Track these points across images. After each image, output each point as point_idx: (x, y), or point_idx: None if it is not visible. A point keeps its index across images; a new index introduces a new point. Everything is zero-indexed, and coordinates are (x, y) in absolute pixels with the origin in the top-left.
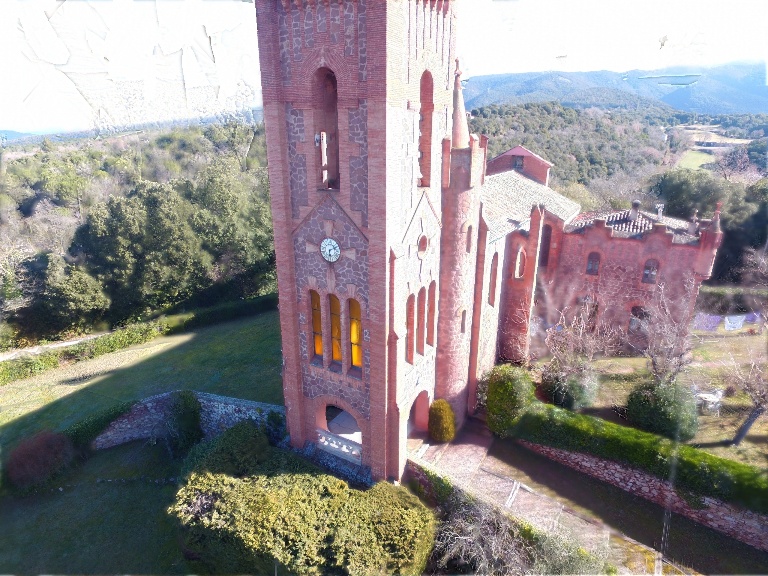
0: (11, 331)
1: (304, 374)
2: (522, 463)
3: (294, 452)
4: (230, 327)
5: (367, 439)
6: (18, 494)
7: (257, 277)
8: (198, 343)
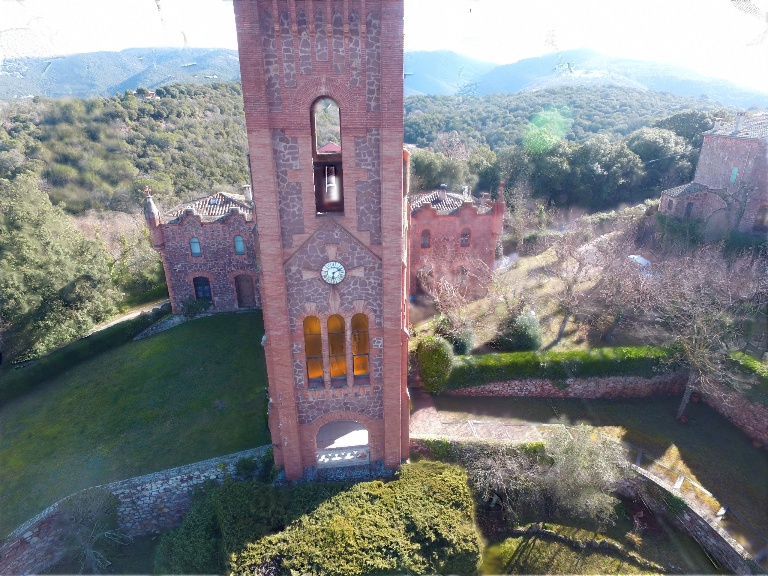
0: None
1: (299, 403)
2: (460, 407)
3: None
4: (36, 402)
5: (376, 436)
6: None
7: None
8: (3, 438)
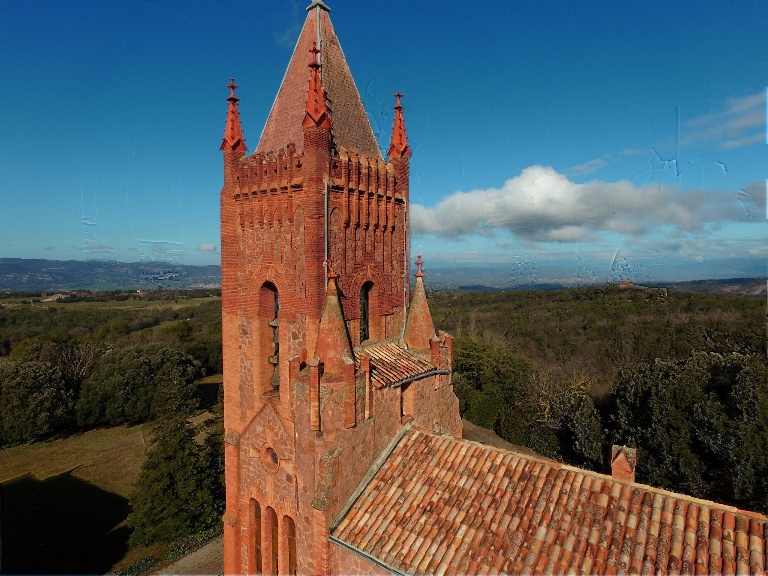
0: (556, 445)
1: None
2: None
3: None
4: None
5: None
6: None
7: None
8: None
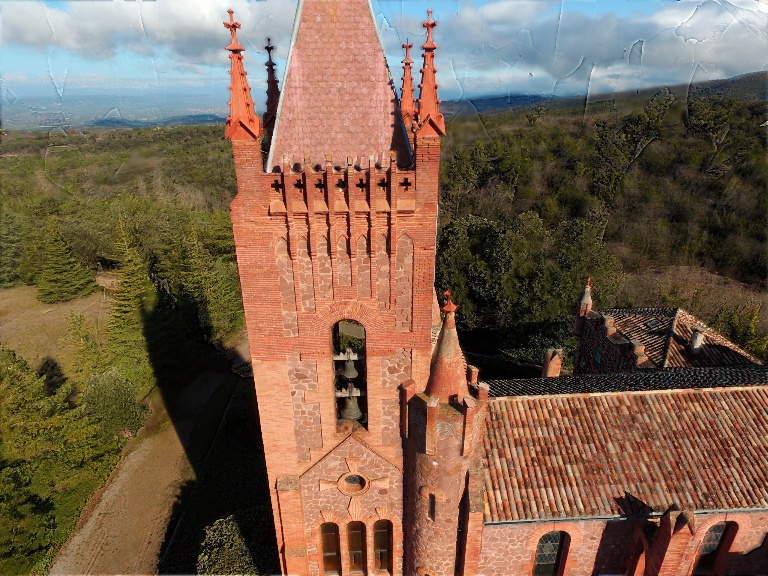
0: None
1: None
2: None
3: None
4: None
5: None
6: None
7: (525, 335)
8: None
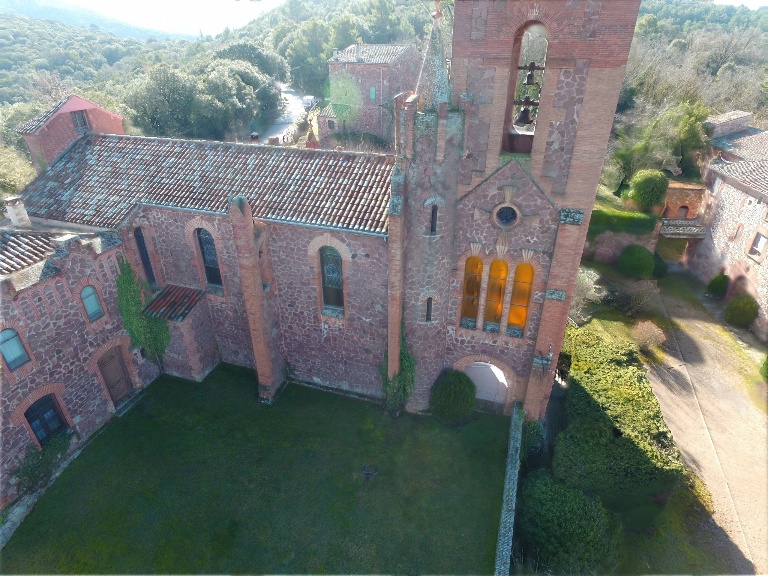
0: None
1: None
2: None
3: None
4: None
5: None
6: None
7: None
8: None
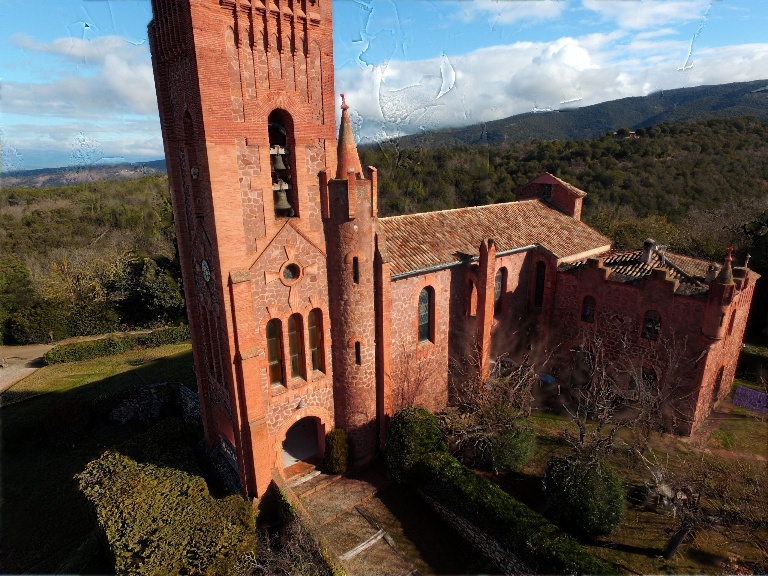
0: (116, 317)
1: (209, 381)
2: (406, 514)
3: (205, 452)
4: None
5: None
6: (47, 443)
7: None
8: None
